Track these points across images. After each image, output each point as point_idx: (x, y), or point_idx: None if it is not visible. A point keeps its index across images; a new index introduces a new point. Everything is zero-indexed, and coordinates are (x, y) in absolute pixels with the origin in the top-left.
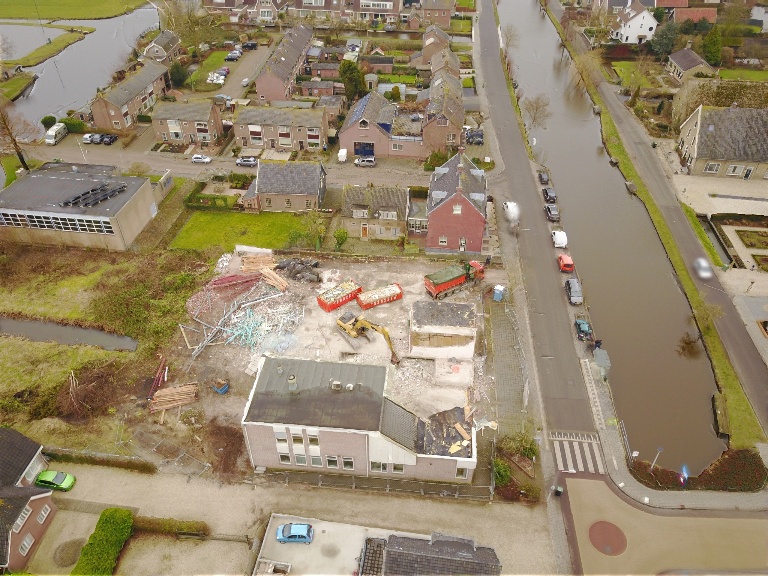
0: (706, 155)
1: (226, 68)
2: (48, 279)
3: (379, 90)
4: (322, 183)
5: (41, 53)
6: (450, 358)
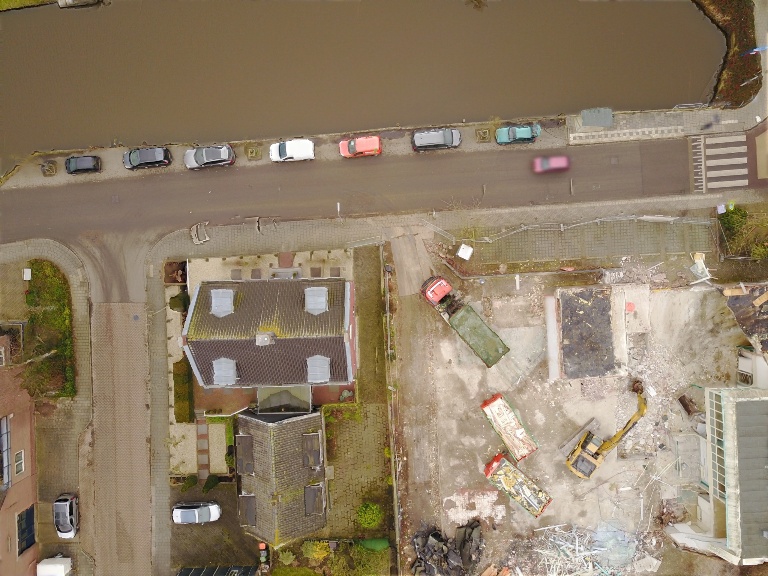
0: None
1: None
2: None
3: None
4: None
5: None
6: None
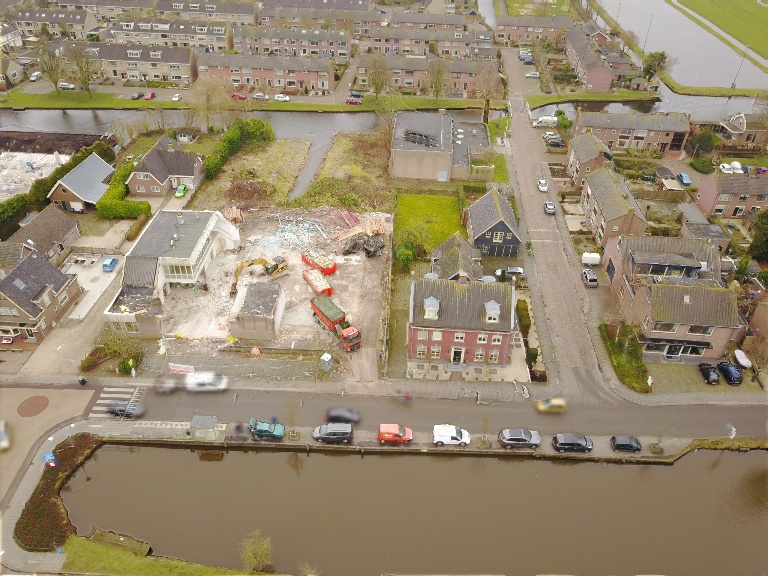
0: None
1: (763, 169)
2: (358, 160)
3: None
4: (503, 241)
5: (704, 89)
6: None
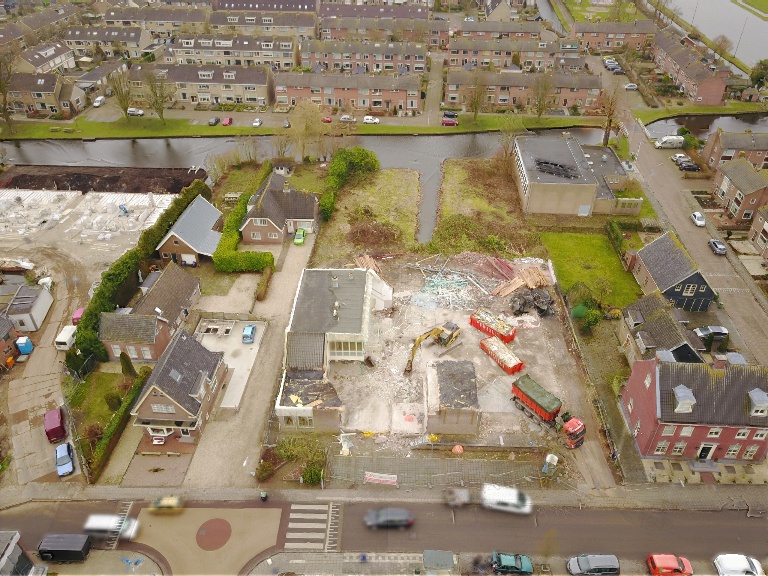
0: None
1: None
2: (479, 193)
3: None
4: (694, 294)
5: None
6: (424, 414)
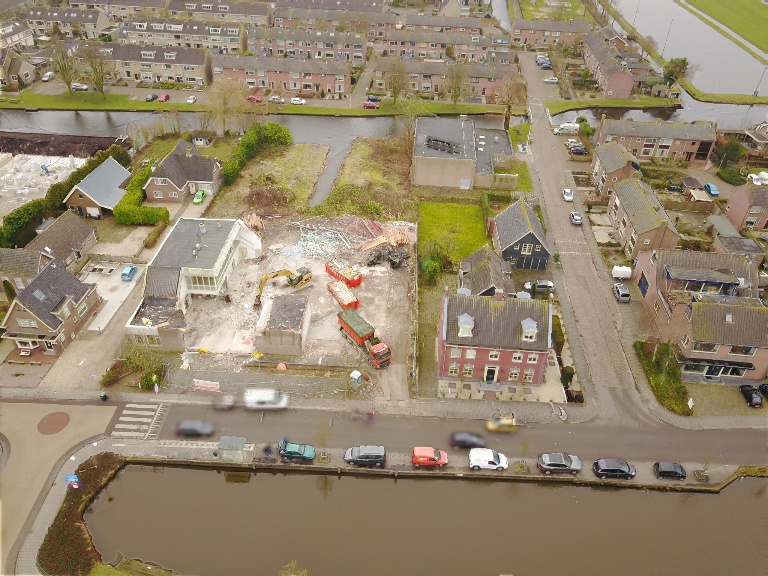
0: None
1: None
2: None
3: None
4: (531, 253)
5: (725, 96)
6: None
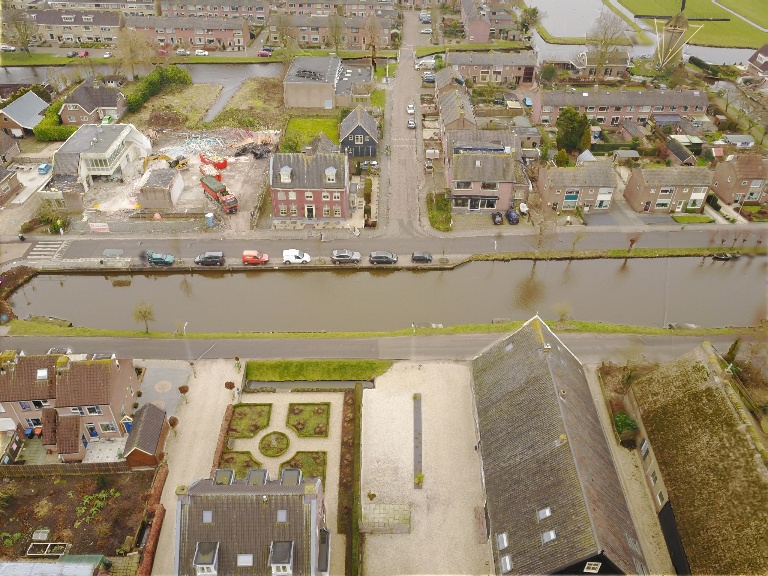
0: (476, 367)
1: None
2: None
3: (581, 155)
4: (363, 143)
5: (571, 39)
6: None
